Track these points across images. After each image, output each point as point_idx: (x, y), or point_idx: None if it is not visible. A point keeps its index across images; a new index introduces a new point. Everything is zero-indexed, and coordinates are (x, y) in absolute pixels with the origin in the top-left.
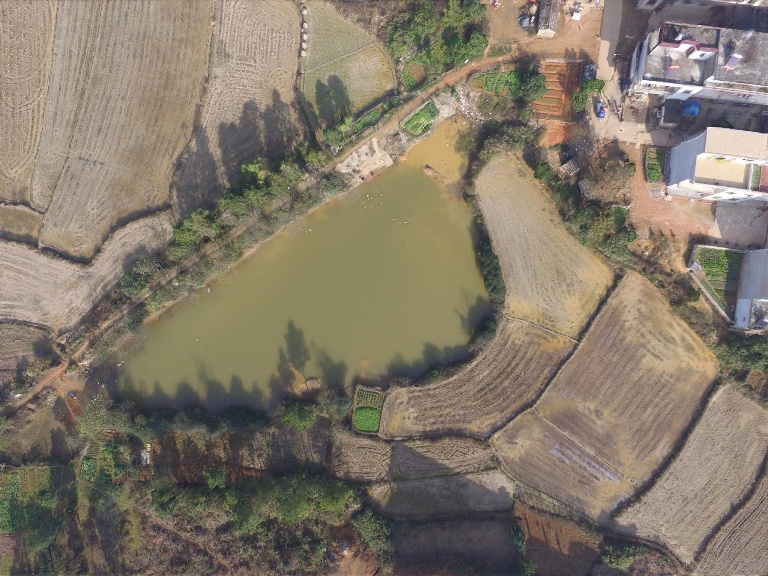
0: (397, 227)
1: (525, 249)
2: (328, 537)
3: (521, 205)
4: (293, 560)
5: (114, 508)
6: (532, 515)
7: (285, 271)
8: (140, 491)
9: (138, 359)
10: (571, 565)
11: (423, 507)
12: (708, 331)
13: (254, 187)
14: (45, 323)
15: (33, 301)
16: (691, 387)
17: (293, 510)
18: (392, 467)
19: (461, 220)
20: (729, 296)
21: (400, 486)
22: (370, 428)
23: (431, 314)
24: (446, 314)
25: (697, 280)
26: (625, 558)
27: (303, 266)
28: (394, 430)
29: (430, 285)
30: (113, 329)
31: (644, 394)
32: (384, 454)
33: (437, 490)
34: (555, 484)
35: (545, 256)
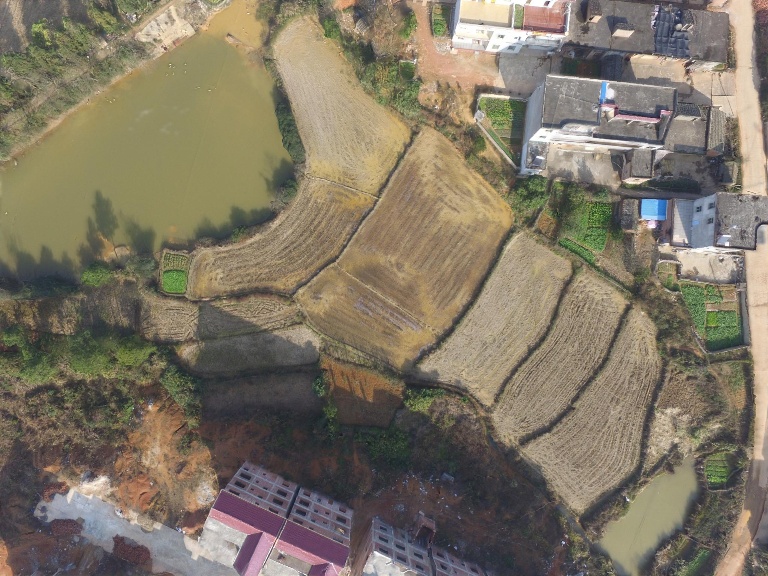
0: (201, 95)
1: (324, 110)
2: (136, 396)
3: (319, 68)
4: (97, 416)
5: None
6: (337, 366)
7: (91, 141)
8: None
9: None
10: (376, 412)
11: (231, 364)
12: (498, 180)
13: (35, 44)
14: None
15: None
16: (488, 237)
17: (84, 359)
18: (200, 327)
19: (264, 86)
20: (515, 144)
21: (208, 345)
22: (177, 290)
23: (237, 178)
24: (252, 178)
25: (483, 129)
26: (420, 398)
27: (109, 136)
28: (201, 291)
29: (235, 150)
30: None
31: (443, 245)
32: (192, 315)
33: (245, 347)
34: (359, 336)
35: (344, 117)
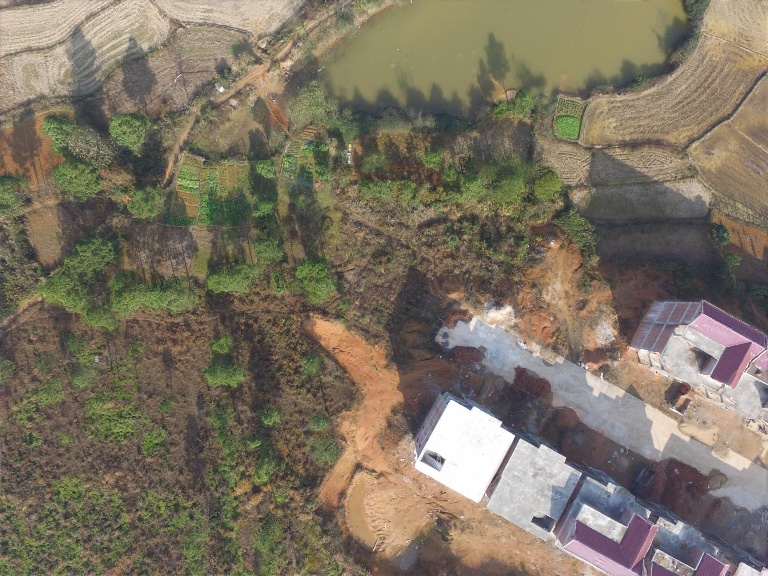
0: None
1: None
2: (530, 235)
3: None
4: (502, 247)
5: (315, 204)
6: (728, 222)
7: None
8: (342, 188)
9: (338, 65)
10: (765, 270)
11: (622, 212)
12: None
13: None
14: (245, 28)
15: (233, 6)
16: None
17: (516, 181)
18: (592, 173)
19: None
20: None
21: (599, 192)
22: (571, 135)
23: (629, 32)
24: (643, 33)
25: None
26: None
27: None
28: (594, 139)
29: (628, 5)
30: (319, 29)
31: None
32: (584, 161)
33: (635, 196)
34: (749, 194)
35: None
